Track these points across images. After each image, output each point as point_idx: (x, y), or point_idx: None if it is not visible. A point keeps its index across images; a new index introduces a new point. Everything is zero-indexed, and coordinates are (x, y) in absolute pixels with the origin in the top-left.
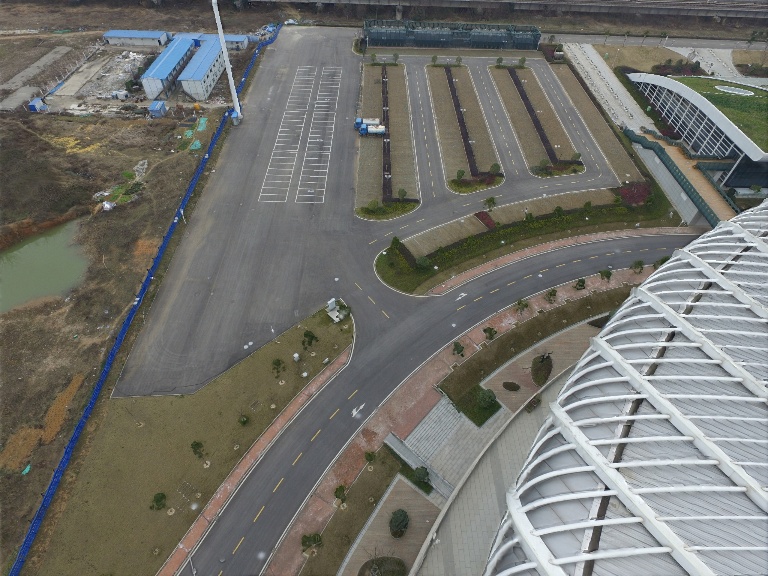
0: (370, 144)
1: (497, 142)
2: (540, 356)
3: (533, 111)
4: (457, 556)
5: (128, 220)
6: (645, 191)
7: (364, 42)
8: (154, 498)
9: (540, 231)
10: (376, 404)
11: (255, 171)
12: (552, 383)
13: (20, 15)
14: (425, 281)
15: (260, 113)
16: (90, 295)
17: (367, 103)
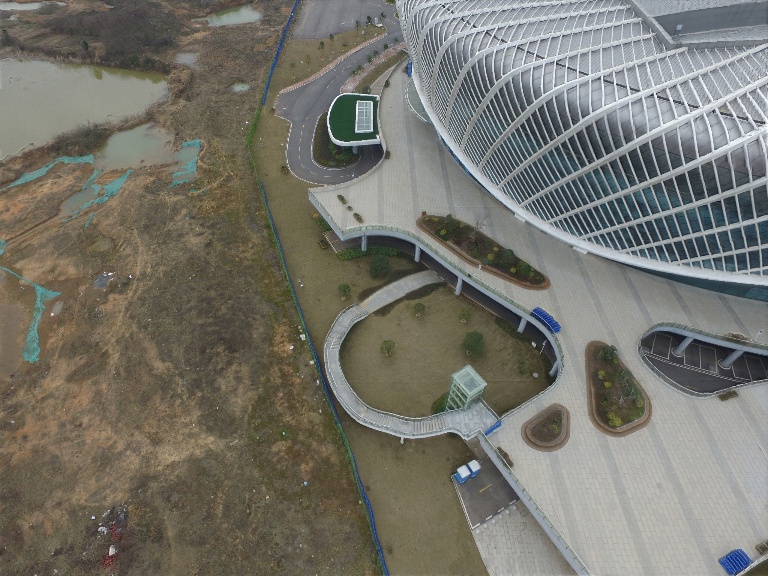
0: None
1: None
2: None
3: None
4: None
5: (273, 4)
6: None
7: None
8: (321, 42)
9: None
10: (397, 44)
11: None
12: None
13: None
14: None
15: None
16: None
17: None
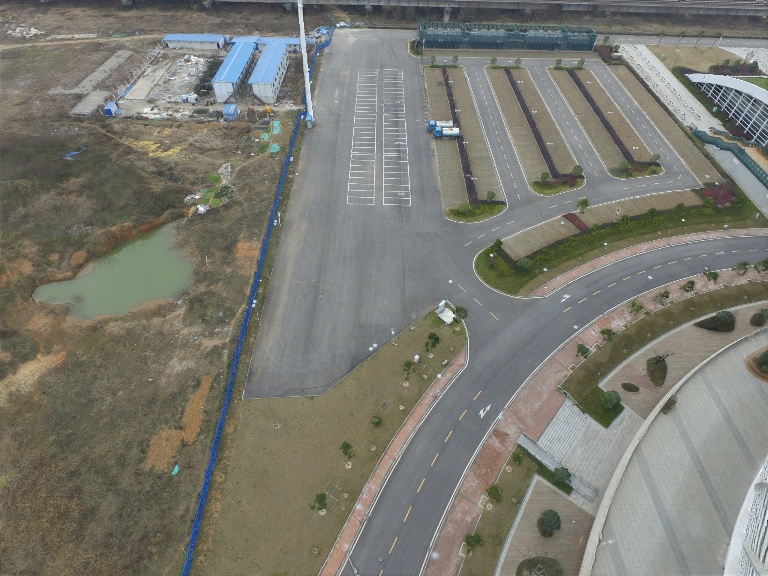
0: (445, 146)
1: (571, 144)
2: (653, 357)
3: (601, 112)
4: (625, 556)
5: (223, 223)
6: (728, 192)
7: (420, 44)
8: (318, 498)
9: (631, 233)
10: (502, 405)
11: (338, 174)
12: (683, 384)
13: (75, 19)
14: (527, 283)
15: (331, 116)
16: (202, 297)
17: (434, 105)
